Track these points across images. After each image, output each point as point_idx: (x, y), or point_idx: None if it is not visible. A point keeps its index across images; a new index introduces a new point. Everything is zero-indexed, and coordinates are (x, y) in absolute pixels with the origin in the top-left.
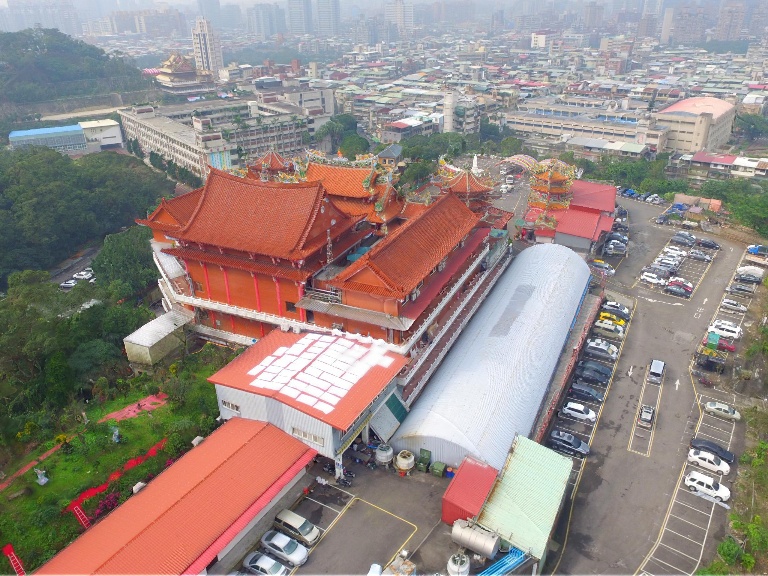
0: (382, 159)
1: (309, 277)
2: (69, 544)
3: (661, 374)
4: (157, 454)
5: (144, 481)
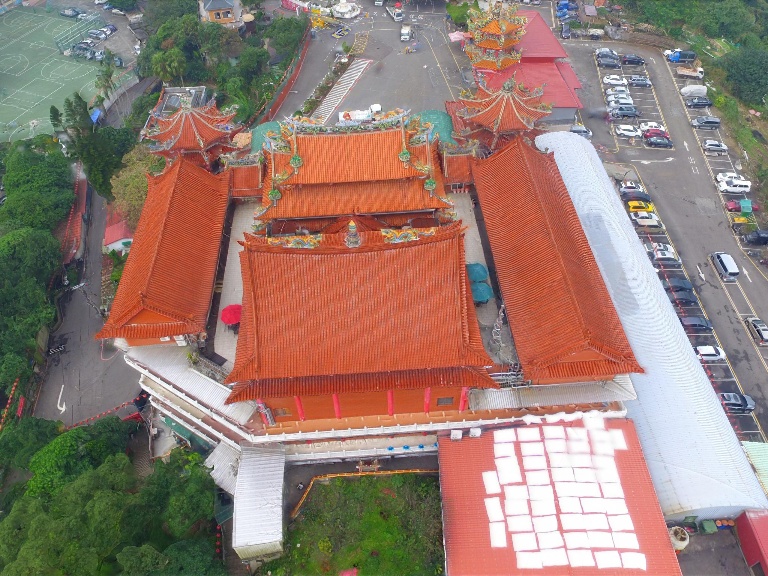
0: (213, 13)
1: None
2: None
3: (738, 272)
4: None
5: None
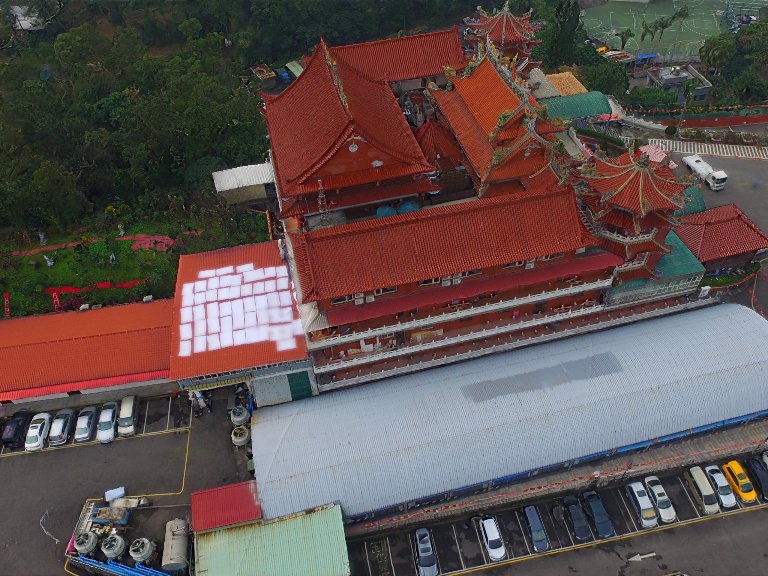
0: None
1: (301, 214)
2: (33, 315)
3: None
4: (131, 288)
5: (104, 303)
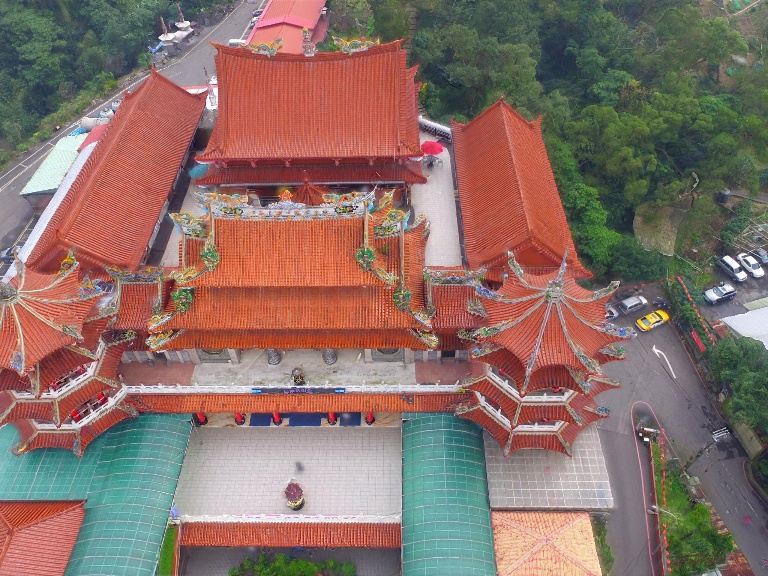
0: None
1: None
2: None
3: None
4: None
5: None
